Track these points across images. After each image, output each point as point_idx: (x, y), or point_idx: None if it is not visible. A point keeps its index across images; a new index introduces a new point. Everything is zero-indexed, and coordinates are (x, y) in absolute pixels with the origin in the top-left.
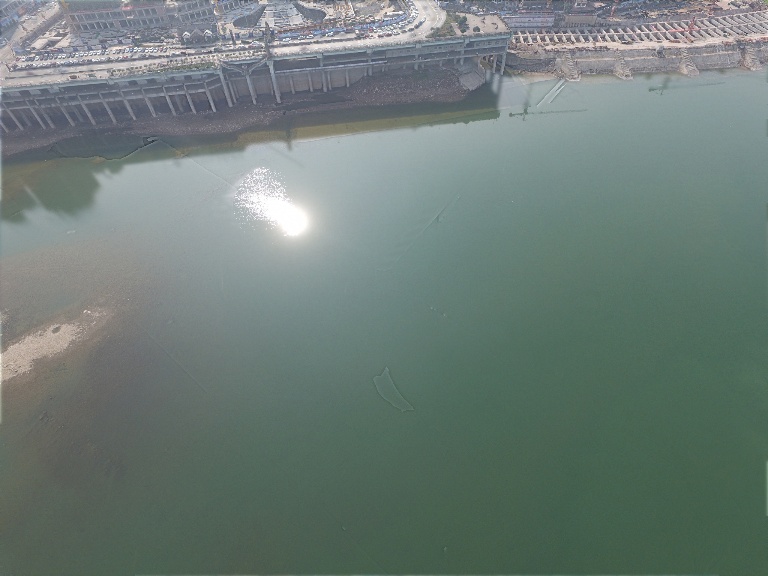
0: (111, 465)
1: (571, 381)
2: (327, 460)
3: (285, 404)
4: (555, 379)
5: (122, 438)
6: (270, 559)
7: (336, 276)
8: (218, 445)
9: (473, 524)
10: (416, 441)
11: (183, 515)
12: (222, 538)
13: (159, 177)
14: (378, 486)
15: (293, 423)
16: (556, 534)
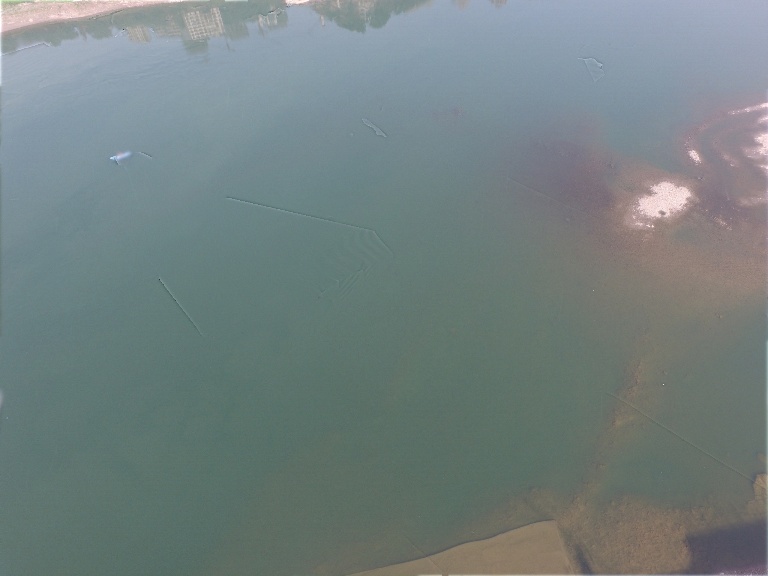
0: (545, 148)
1: (250, 185)
2: (417, 158)
3: (454, 195)
4: (260, 190)
5: (548, 157)
6: (439, 126)
7: (433, 280)
8: (488, 165)
9: (336, 139)
10: (363, 157)
11: (488, 128)
12: (465, 126)
13: (754, 425)
14: (386, 140)
15: (445, 184)
16: (296, 129)
